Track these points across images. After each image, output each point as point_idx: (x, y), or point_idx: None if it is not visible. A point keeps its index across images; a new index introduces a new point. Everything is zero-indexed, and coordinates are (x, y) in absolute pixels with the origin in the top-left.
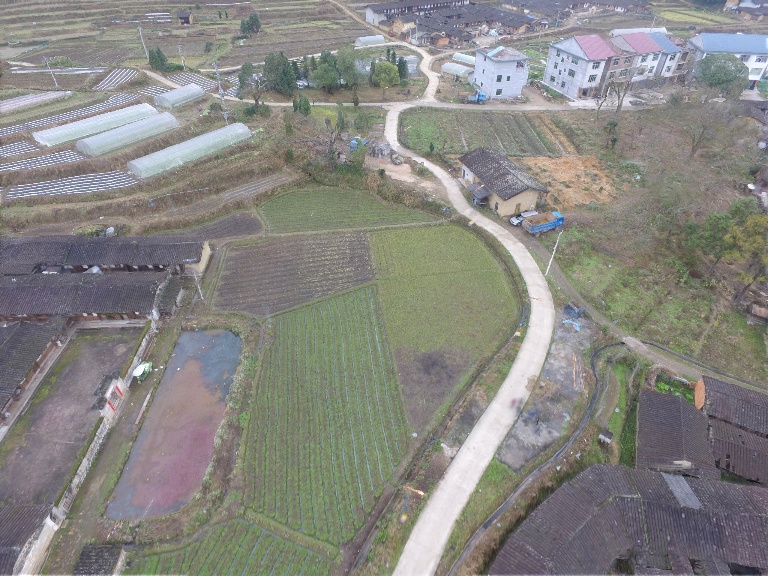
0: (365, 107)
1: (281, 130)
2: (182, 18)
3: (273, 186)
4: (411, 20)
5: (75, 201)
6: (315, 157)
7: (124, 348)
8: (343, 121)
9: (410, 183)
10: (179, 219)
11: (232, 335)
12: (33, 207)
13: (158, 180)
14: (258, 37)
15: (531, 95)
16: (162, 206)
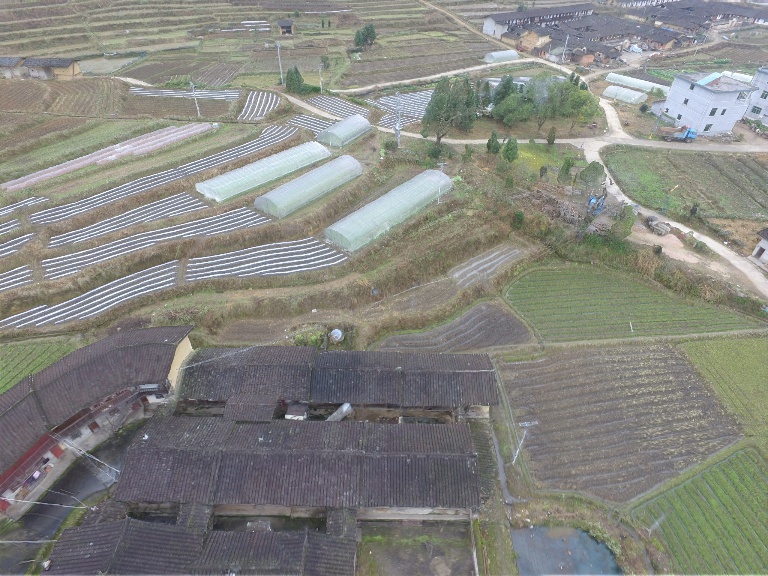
0: (555, 145)
1: (484, 179)
2: (284, 27)
3: (511, 263)
4: (547, 33)
5: (276, 286)
6: (555, 223)
7: (446, 567)
8: (568, 171)
9: (695, 265)
10: (416, 315)
11: (591, 541)
12: (225, 294)
13: (368, 254)
14: (373, 50)
15: (739, 131)
16: (386, 294)
